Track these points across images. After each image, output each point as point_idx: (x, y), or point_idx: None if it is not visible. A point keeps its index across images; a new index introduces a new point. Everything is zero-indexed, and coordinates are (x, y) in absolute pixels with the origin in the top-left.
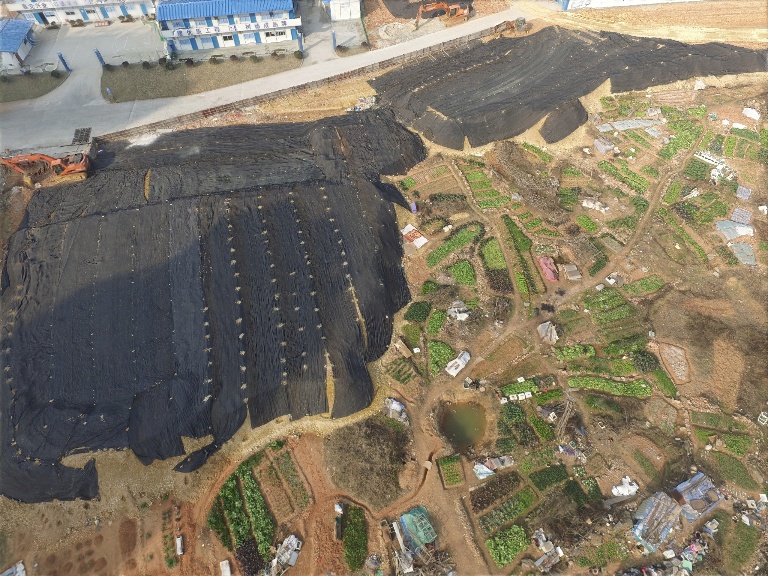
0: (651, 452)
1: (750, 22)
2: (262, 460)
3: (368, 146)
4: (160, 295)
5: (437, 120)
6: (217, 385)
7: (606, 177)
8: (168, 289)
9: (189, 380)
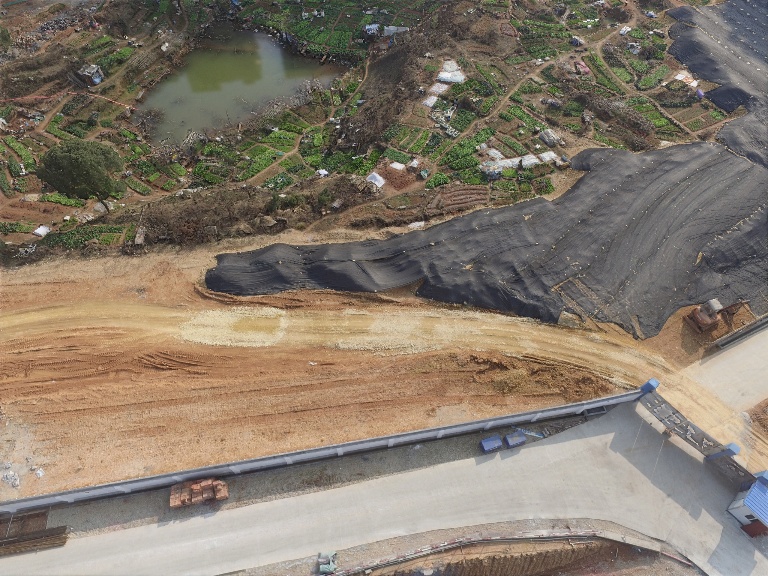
0: (528, 3)
1: (265, 370)
2: (701, 3)
3: None
4: None
5: None
6: (748, 4)
7: (542, 122)
8: None
9: (764, 4)
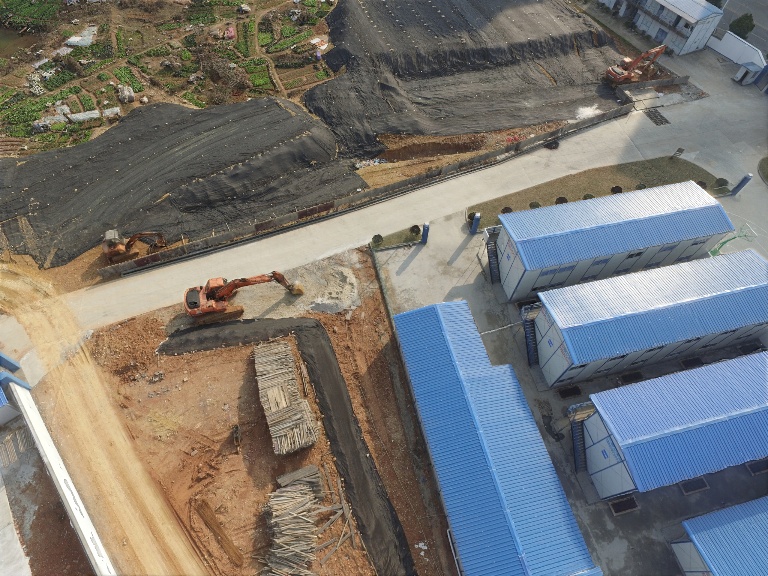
0: None
1: None
2: None
3: (359, 93)
4: (476, 3)
5: (287, 105)
6: None
7: (144, 82)
8: (473, 4)
9: None
